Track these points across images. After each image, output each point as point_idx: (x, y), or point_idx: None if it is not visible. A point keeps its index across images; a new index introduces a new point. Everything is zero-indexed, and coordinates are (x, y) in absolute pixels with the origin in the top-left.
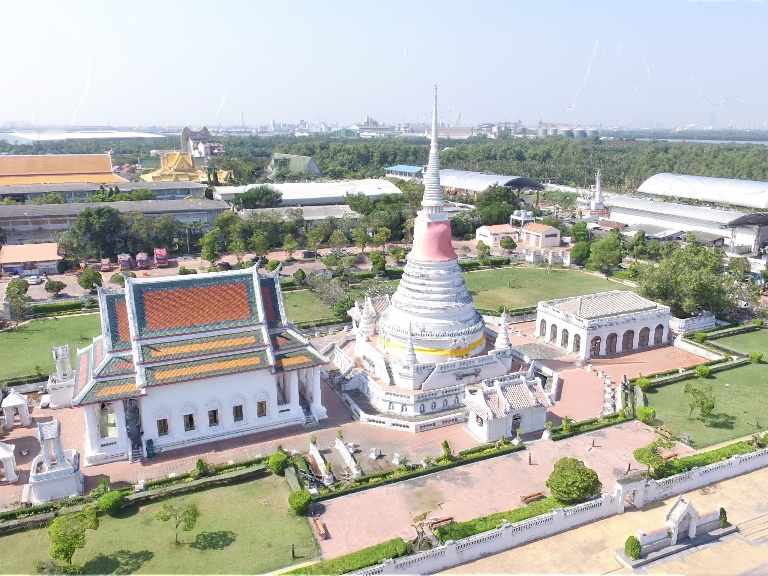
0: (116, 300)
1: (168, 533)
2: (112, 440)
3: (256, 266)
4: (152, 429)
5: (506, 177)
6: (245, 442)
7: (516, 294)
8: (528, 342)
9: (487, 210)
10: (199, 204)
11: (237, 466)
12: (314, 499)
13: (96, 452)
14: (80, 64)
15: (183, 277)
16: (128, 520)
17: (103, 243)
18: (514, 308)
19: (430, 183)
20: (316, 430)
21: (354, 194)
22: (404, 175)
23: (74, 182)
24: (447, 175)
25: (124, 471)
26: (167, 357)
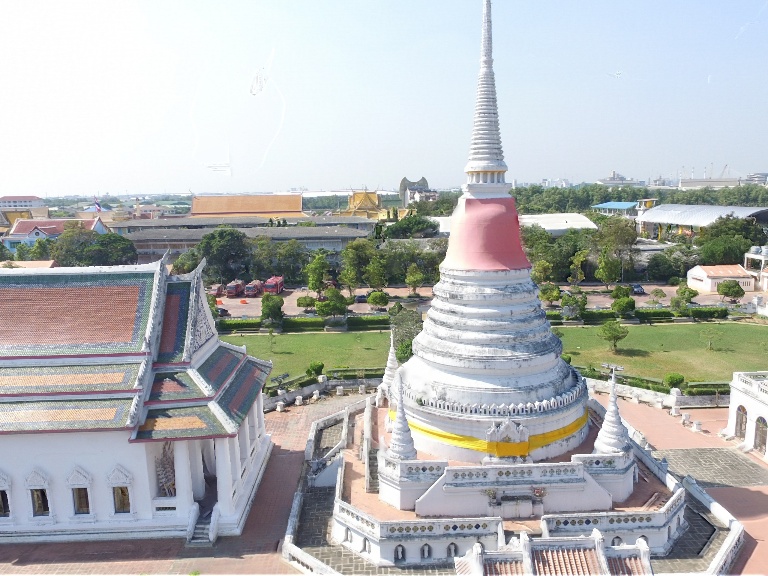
0: None
1: None
2: None
3: (162, 261)
4: None
5: (750, 208)
6: (73, 555)
7: (717, 360)
8: (706, 445)
9: (708, 246)
10: (335, 231)
11: None
12: None
13: None
14: (276, 106)
15: (47, 270)
16: None
17: (225, 268)
18: (699, 381)
19: (475, 130)
20: (196, 556)
21: (525, 225)
22: (613, 213)
23: (249, 216)
24: (668, 210)
25: None
26: None
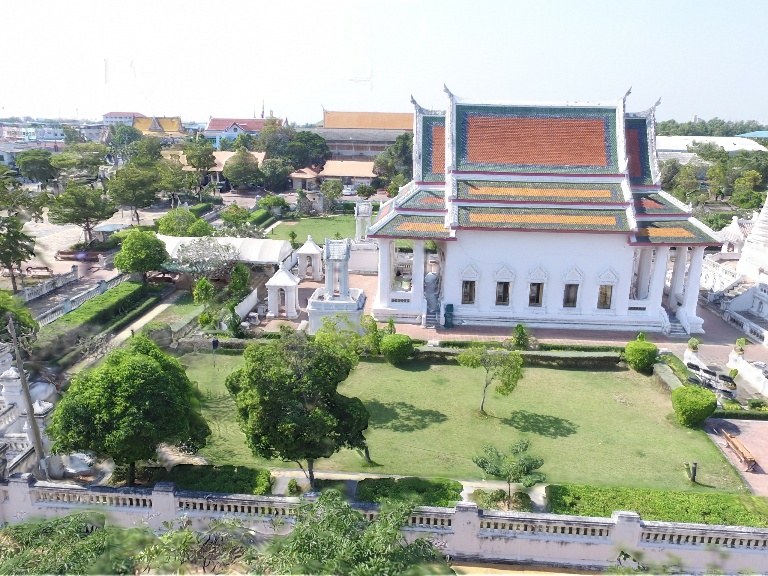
0: (434, 123)
1: (469, 399)
2: (405, 295)
3: (623, 98)
4: (455, 291)
5: None
6: (576, 336)
7: None
8: None
9: None
10: None
11: (572, 349)
12: (713, 412)
13: (385, 306)
14: (416, 20)
15: (520, 103)
16: (415, 374)
17: None
18: None
19: None
20: (687, 342)
21: (704, 143)
22: None
23: None
24: None
25: (414, 333)
26: (488, 197)
